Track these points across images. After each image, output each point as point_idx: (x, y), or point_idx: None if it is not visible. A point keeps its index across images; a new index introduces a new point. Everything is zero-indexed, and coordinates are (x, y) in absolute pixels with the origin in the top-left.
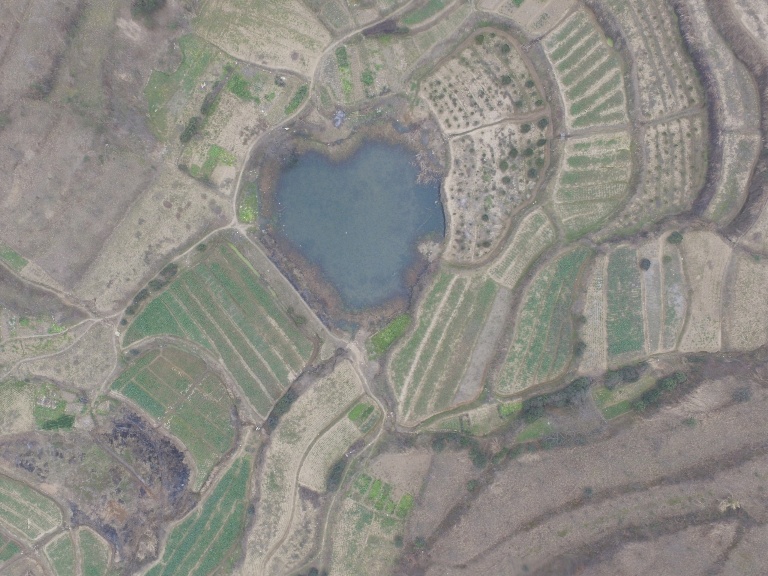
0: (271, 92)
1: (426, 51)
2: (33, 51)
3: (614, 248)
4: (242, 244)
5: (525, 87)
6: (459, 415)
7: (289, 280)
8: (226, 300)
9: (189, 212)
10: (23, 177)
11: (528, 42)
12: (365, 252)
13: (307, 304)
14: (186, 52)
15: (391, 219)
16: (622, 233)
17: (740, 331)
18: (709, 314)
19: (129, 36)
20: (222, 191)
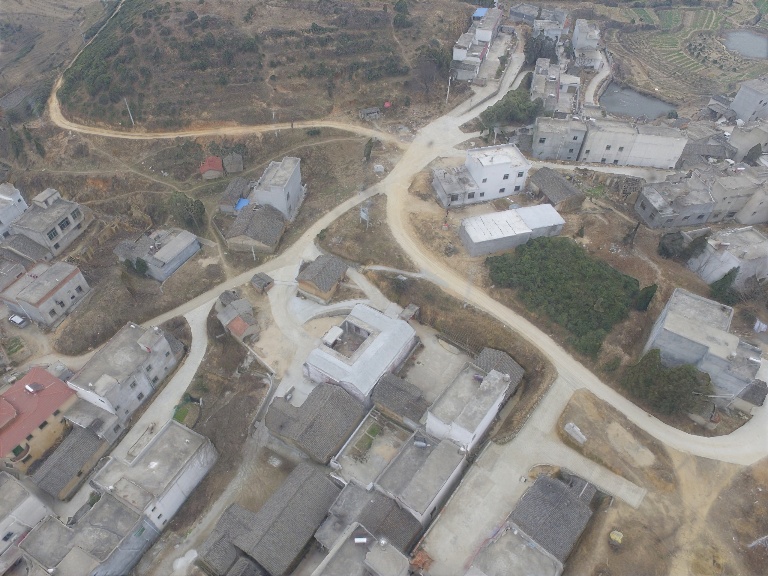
0: None
1: None
2: None
3: None
4: None
5: None
6: (692, 8)
7: None
8: None
9: None
10: None
11: None
12: None
13: None
14: None
15: None
16: None
17: None
18: None
19: None
20: None
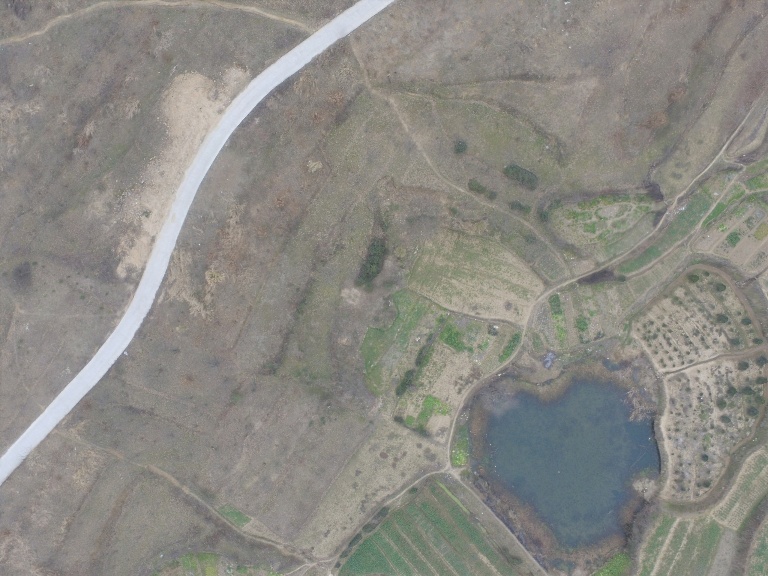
0: (484, 341)
1: (641, 295)
2: (265, 332)
3: None
4: (455, 487)
5: (741, 324)
6: None
7: (505, 523)
8: (437, 539)
9: (404, 461)
10: (250, 445)
11: (744, 280)
12: (577, 488)
13: (524, 547)
14: (400, 307)
15: (603, 455)
16: None
17: None
18: None
19: (350, 303)
20: (437, 440)
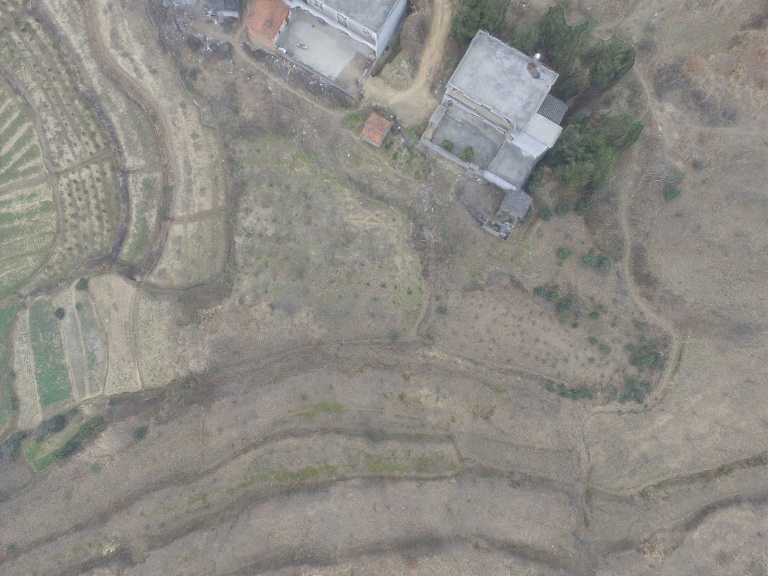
0: None
1: None
2: None
3: (33, 301)
4: None
5: None
6: None
7: None
8: None
9: None
10: None
11: None
12: None
13: None
14: None
15: None
16: (48, 284)
17: (148, 369)
18: (122, 355)
19: None
20: None
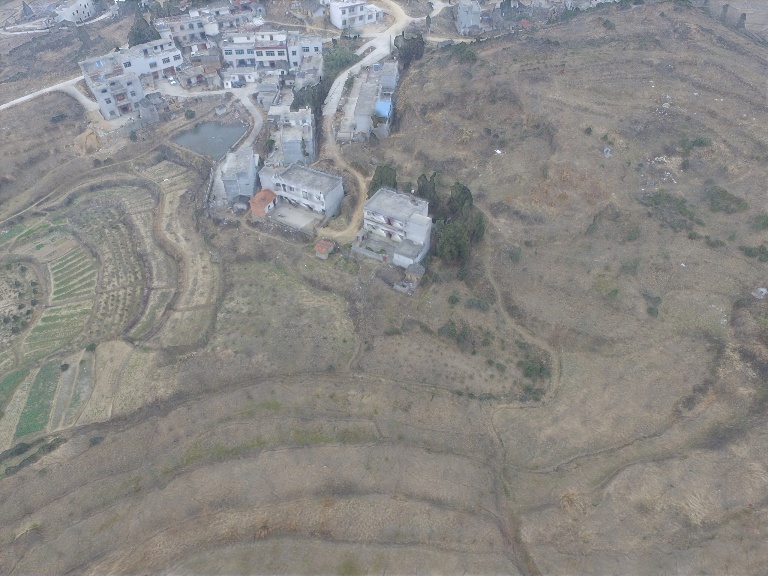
0: None
1: None
2: None
3: None
4: None
5: (31, 286)
6: None
7: None
8: None
9: None
10: None
11: (41, 265)
12: None
13: None
14: None
15: None
16: None
17: (121, 400)
18: (103, 393)
19: None
20: None
